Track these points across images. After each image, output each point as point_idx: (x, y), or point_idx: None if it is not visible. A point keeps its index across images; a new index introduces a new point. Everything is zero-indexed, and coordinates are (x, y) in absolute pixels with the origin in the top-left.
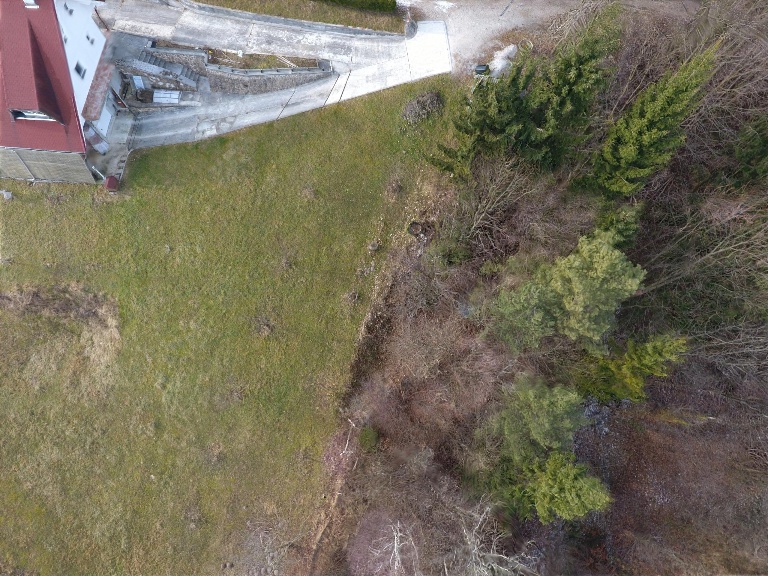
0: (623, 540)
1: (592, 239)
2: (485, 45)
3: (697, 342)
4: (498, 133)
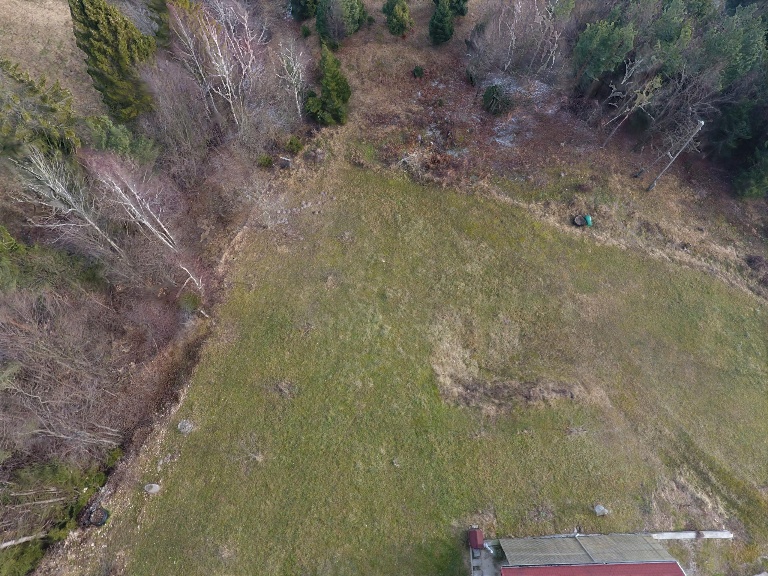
0: None
1: None
2: None
3: None
4: None
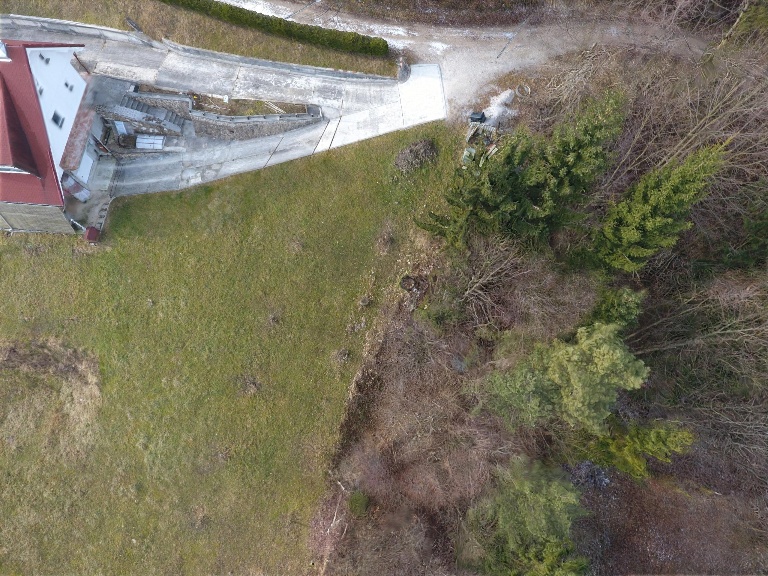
0: None
1: (592, 332)
2: (481, 90)
3: (702, 415)
4: (492, 210)
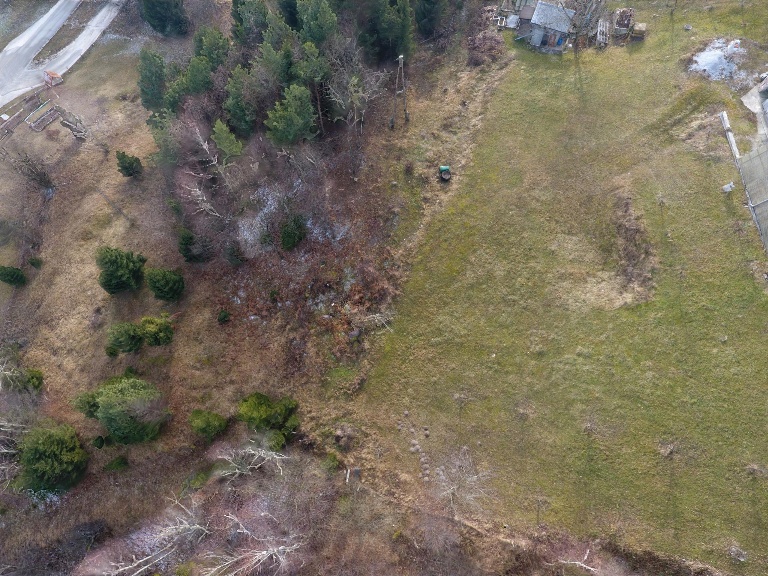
0: None
1: None
2: None
3: None
4: None
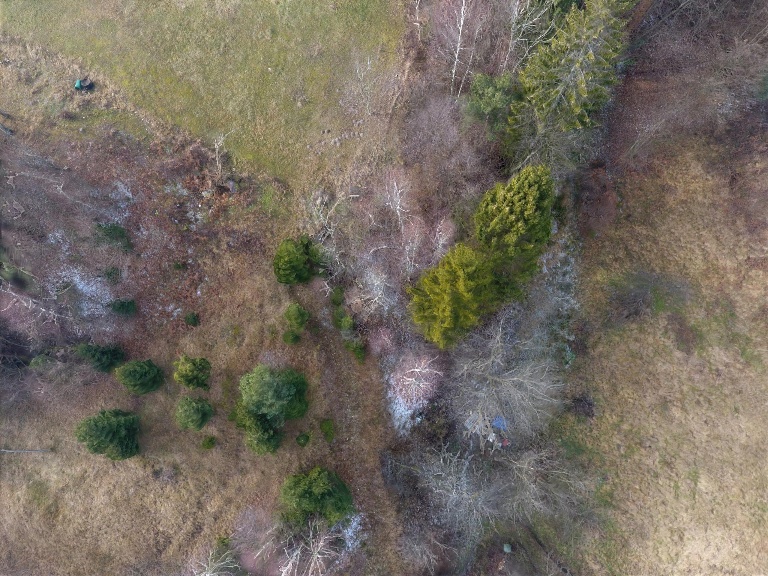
0: (618, 163)
1: None
2: None
3: None
4: None
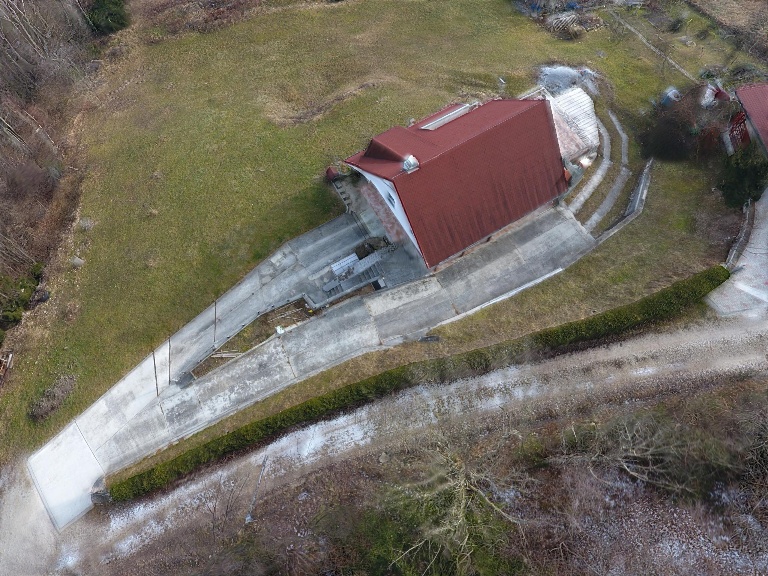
0: None
1: None
2: None
3: None
4: None
